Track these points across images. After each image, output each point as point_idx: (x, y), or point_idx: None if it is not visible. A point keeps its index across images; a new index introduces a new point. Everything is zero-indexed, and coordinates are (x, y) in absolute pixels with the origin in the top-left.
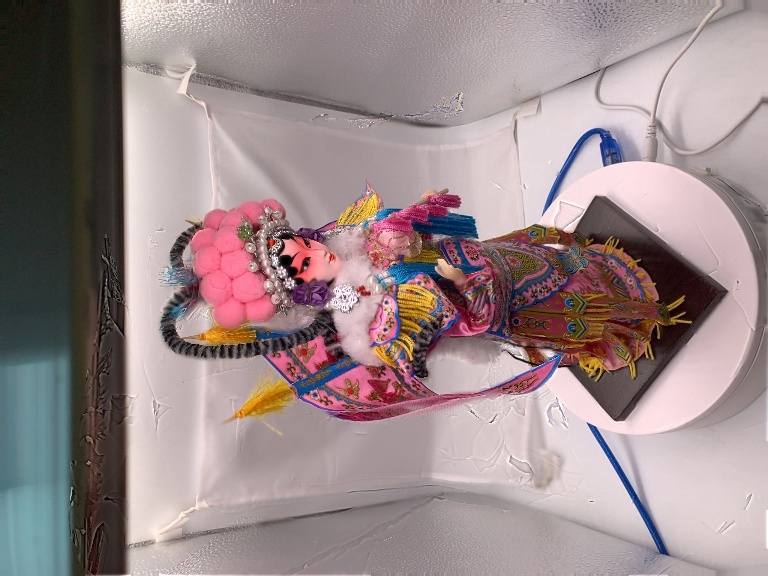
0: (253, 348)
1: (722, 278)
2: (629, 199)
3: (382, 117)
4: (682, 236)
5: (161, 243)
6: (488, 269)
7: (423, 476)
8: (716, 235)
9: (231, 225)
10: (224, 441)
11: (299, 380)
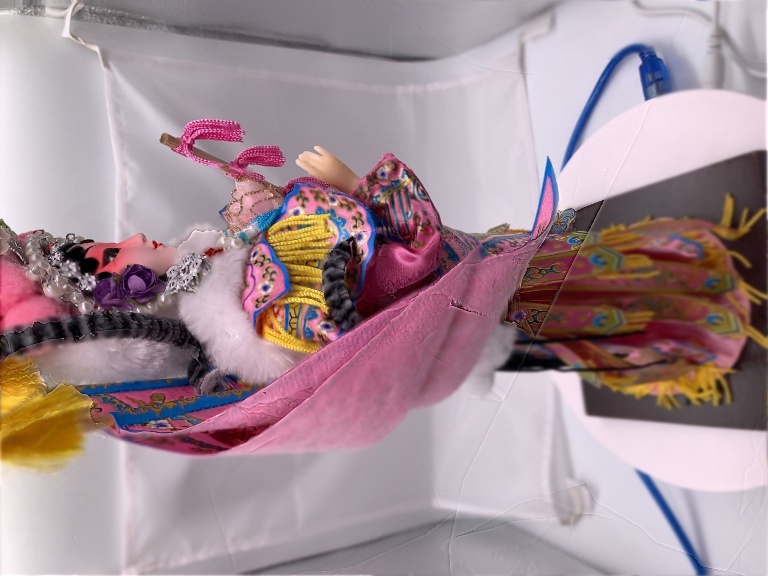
0: None
1: None
2: (595, 191)
3: None
4: None
5: None
6: (387, 155)
7: (446, 505)
8: None
9: None
10: None
11: None
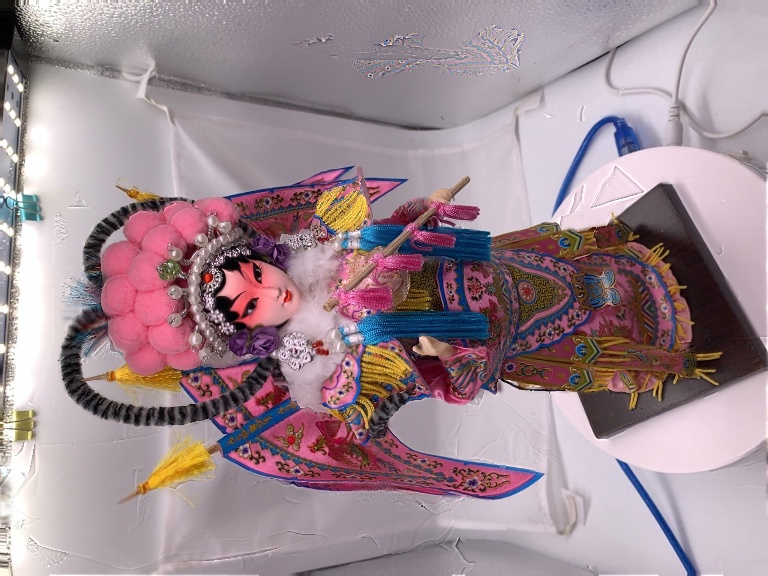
0: (166, 418)
1: None
2: (700, 201)
3: (404, 58)
4: (747, 277)
5: (73, 232)
6: (483, 349)
7: (358, 537)
8: None
9: (154, 251)
10: (122, 514)
11: (228, 434)
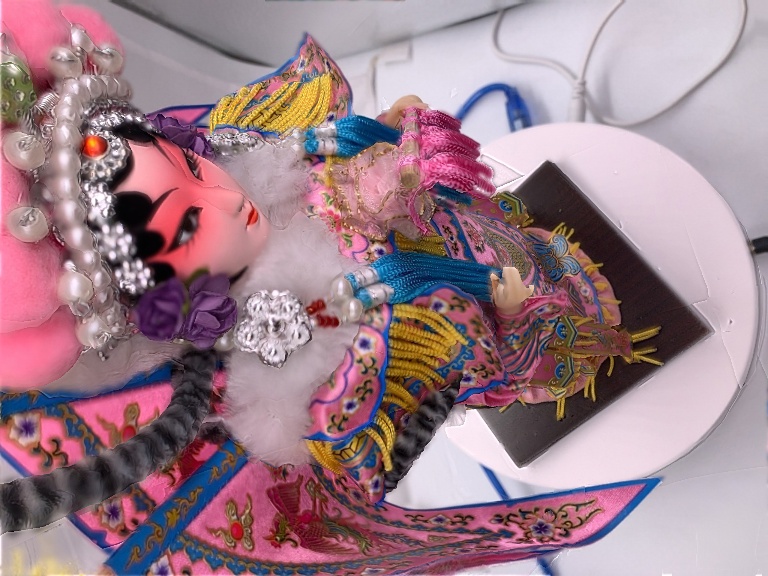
0: None
1: (710, 312)
2: (591, 175)
3: None
4: (663, 244)
5: None
6: (564, 294)
7: None
8: (712, 253)
9: None
10: None
11: (124, 541)
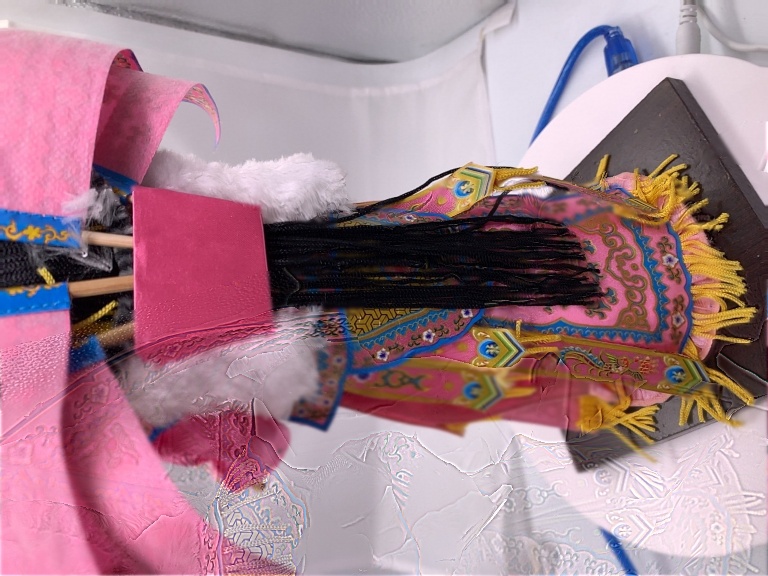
0: None
1: None
2: None
3: (476, 303)
4: None
5: None
6: None
7: None
8: None
9: None
10: None
11: None
